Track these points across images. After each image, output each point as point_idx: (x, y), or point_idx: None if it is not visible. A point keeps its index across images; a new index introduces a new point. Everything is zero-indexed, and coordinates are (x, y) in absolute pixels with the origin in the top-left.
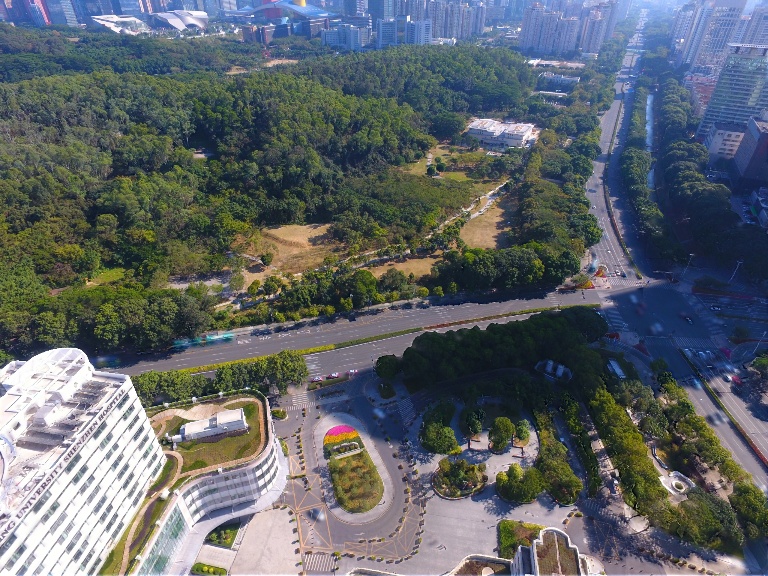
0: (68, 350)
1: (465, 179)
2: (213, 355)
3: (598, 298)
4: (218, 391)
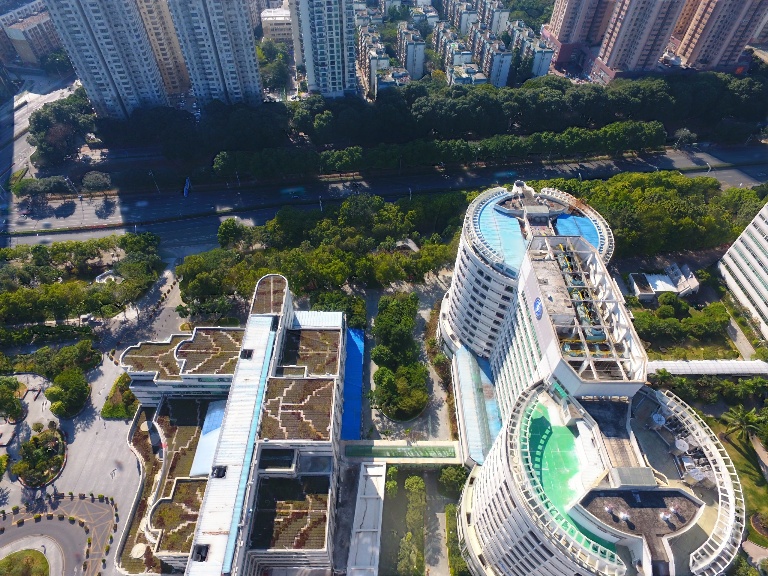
0: None
1: None
2: None
3: None
4: None
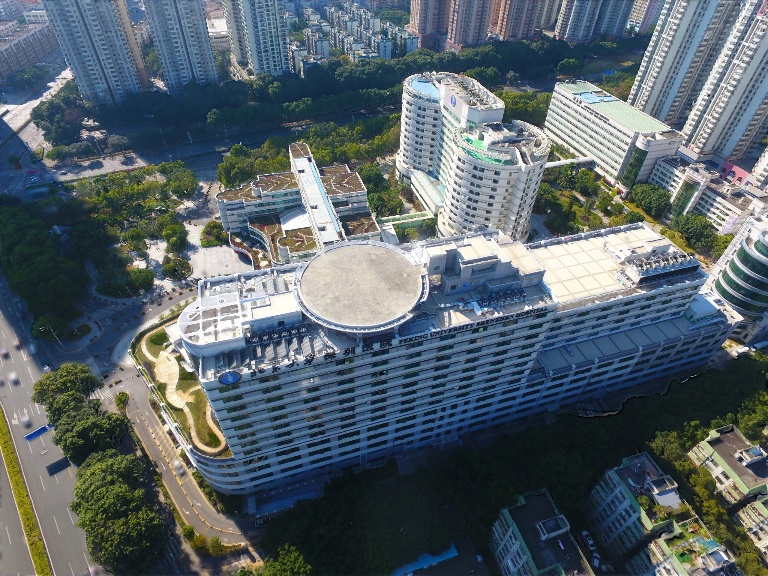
0: None
1: None
2: None
3: None
4: None
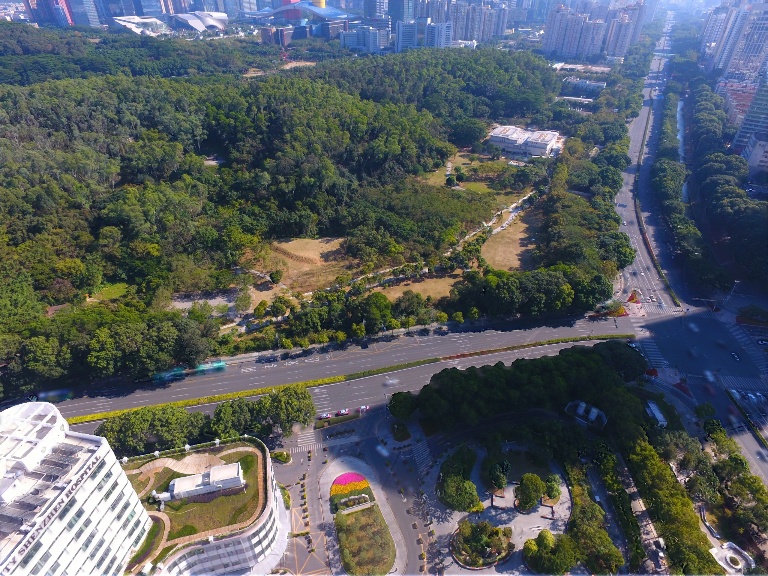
0: (40, 404)
1: (486, 190)
2: (214, 385)
3: (632, 327)
4: (216, 432)
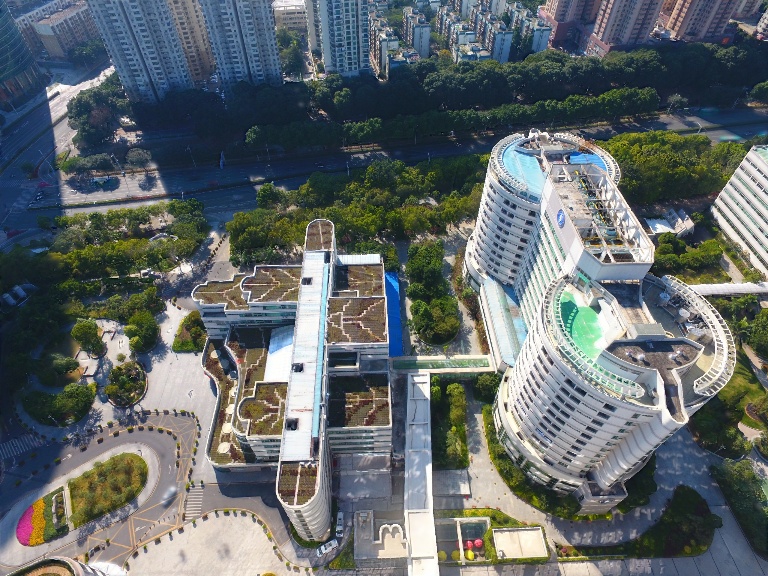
0: None
1: None
2: None
3: None
4: None
